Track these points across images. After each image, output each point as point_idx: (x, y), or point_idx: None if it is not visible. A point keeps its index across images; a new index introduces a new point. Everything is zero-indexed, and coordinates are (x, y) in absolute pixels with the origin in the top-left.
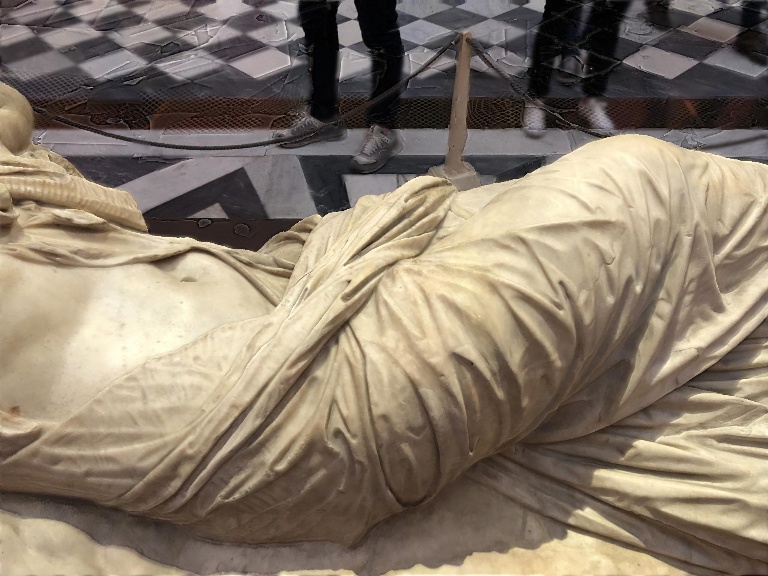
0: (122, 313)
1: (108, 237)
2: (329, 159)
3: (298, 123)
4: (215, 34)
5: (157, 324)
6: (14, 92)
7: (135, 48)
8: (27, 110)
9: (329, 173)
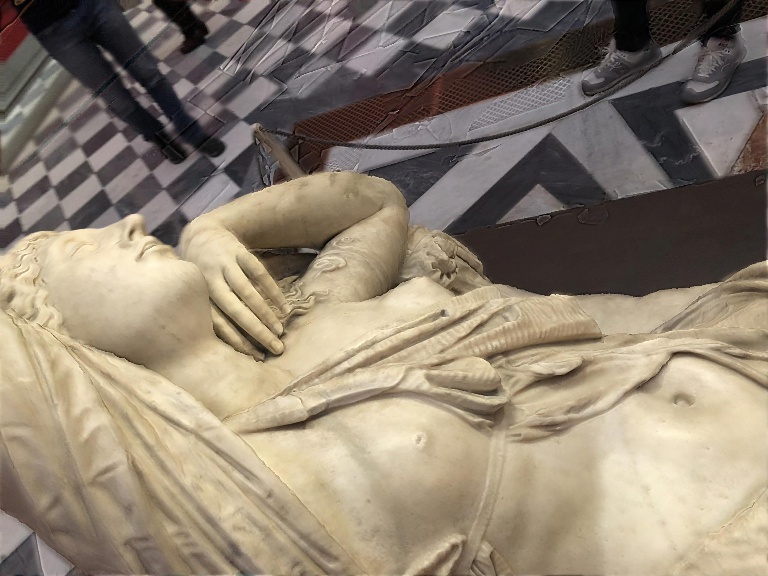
0: (640, 473)
1: (587, 374)
2: (650, 94)
3: (601, 62)
4: (504, 4)
5: (689, 484)
6: (385, 185)
7: (419, 47)
8: (400, 198)
9: (656, 112)
